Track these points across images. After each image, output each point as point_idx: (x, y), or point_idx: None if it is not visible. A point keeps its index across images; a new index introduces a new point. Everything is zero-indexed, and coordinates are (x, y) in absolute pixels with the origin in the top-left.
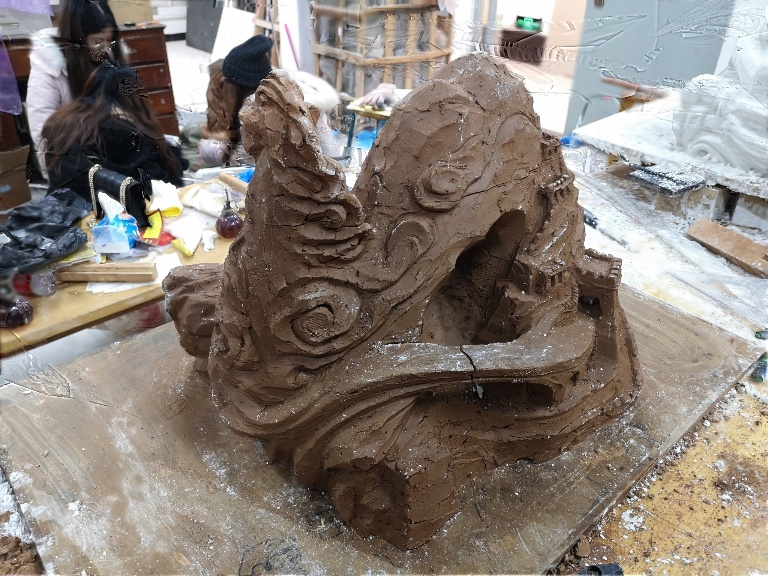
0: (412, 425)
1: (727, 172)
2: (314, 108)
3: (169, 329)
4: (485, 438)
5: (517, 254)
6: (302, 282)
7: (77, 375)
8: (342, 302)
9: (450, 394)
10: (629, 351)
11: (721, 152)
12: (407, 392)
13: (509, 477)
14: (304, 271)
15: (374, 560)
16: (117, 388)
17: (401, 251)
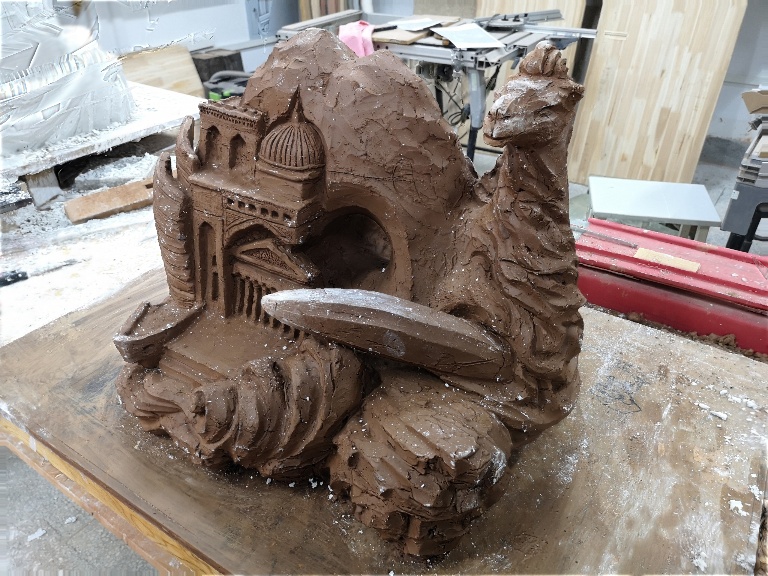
0: None
1: (15, 162)
2: None
3: None
4: None
5: None
6: None
7: None
8: None
9: None
10: None
11: None
12: None
13: None
14: None
15: None
16: None
17: None
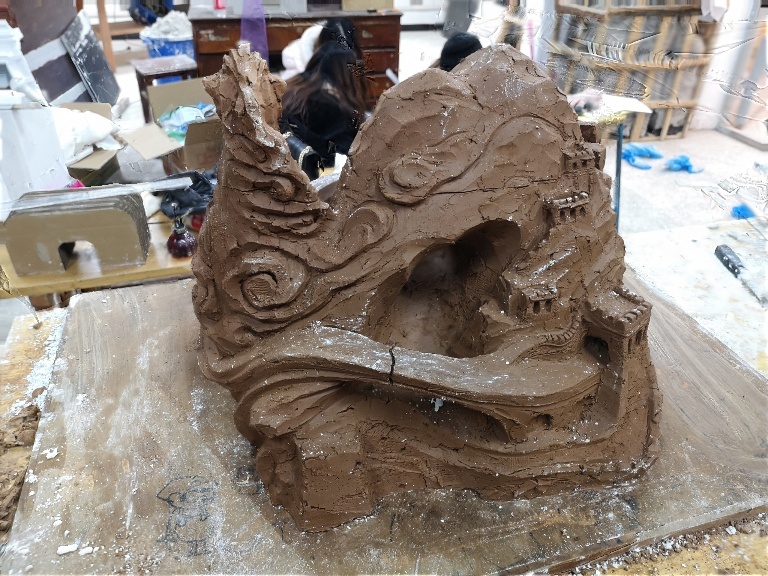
0: (332, 412)
1: None
2: (278, 82)
3: None
4: (429, 453)
5: (506, 269)
6: (252, 247)
7: (145, 297)
8: (287, 274)
9: (396, 396)
10: (649, 415)
11: None
12: (322, 376)
13: (446, 502)
14: (254, 236)
15: (269, 528)
16: (166, 315)
17: (353, 237)
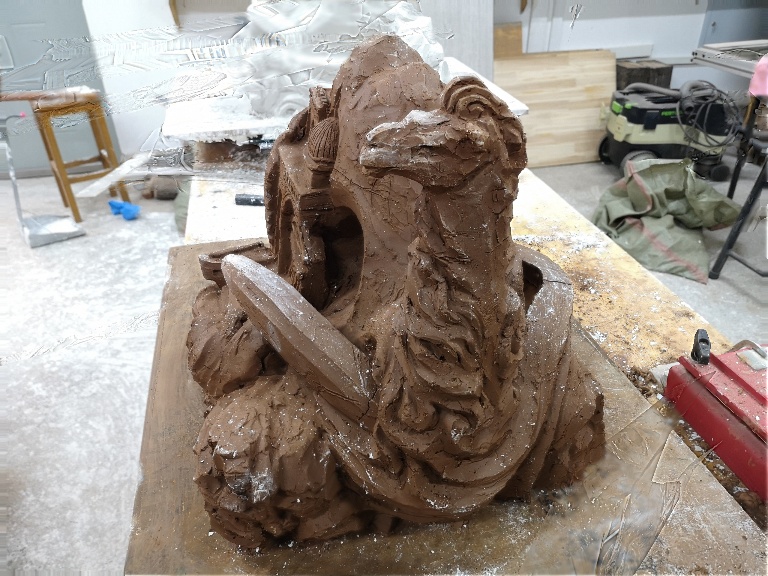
0: None
1: None
2: None
3: (141, 575)
4: None
5: None
6: None
7: None
8: None
9: None
10: None
11: (305, 105)
12: None
13: None
14: None
15: None
16: None
17: None
